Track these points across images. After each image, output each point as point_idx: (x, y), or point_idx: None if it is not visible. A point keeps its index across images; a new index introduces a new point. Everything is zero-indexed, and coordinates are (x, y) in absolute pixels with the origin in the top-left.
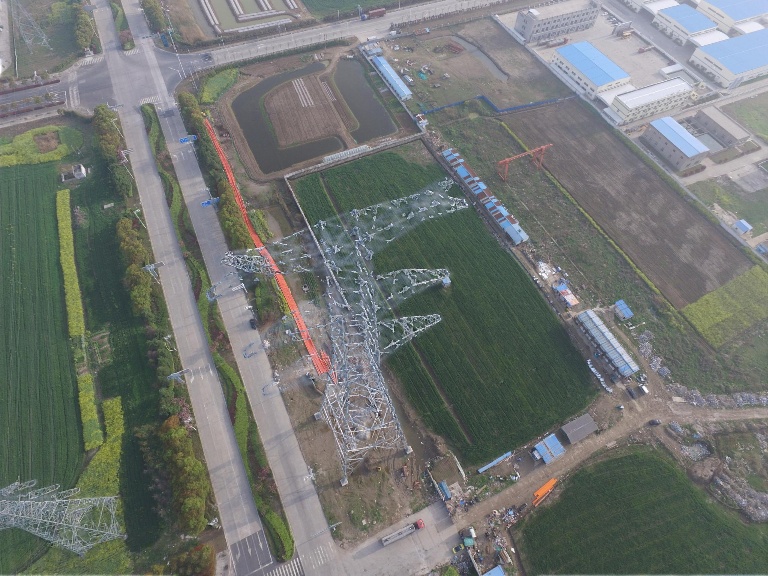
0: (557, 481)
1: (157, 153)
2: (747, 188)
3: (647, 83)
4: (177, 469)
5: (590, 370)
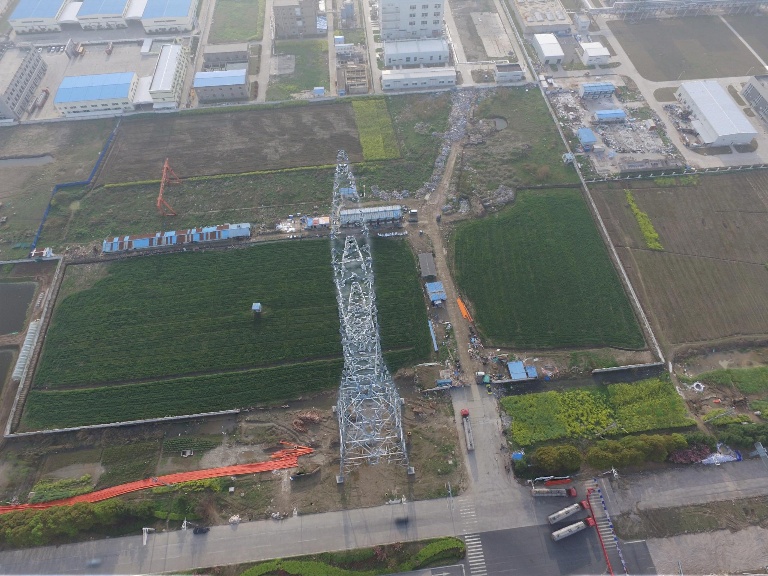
0: (459, 298)
1: None
2: (289, 71)
3: (147, 68)
4: None
5: (386, 237)
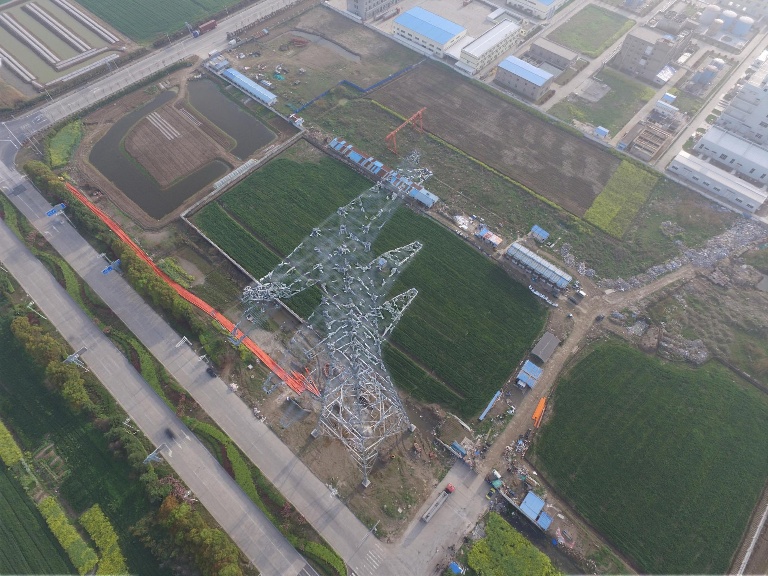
0: (546, 399)
1: (24, 236)
2: (592, 99)
3: (481, 31)
4: (196, 547)
5: (534, 294)
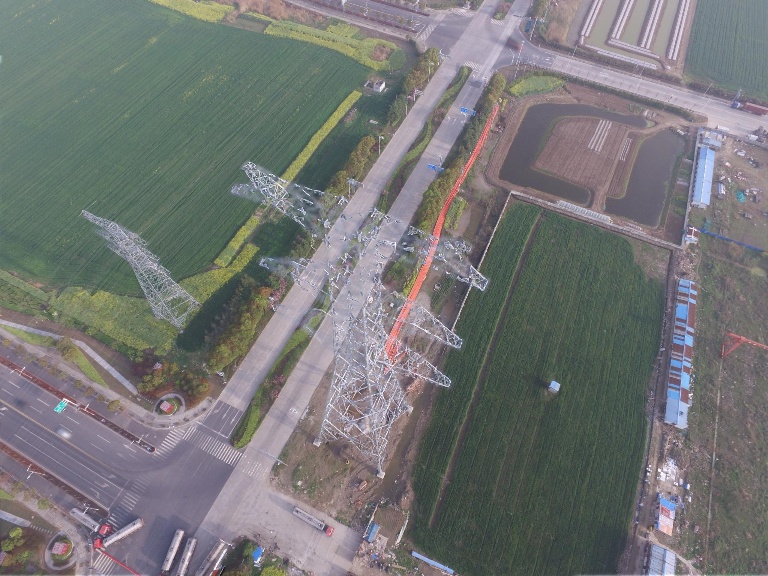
0: None
1: (439, 107)
2: None
3: None
4: (238, 322)
5: None
